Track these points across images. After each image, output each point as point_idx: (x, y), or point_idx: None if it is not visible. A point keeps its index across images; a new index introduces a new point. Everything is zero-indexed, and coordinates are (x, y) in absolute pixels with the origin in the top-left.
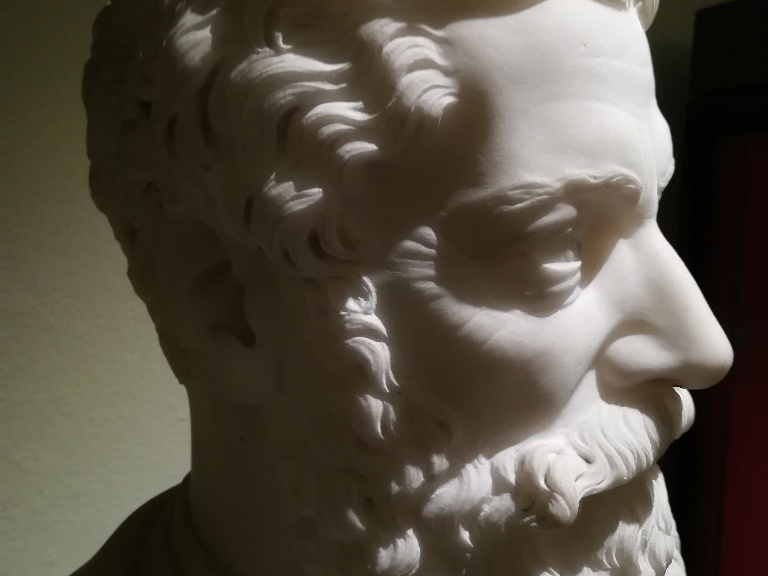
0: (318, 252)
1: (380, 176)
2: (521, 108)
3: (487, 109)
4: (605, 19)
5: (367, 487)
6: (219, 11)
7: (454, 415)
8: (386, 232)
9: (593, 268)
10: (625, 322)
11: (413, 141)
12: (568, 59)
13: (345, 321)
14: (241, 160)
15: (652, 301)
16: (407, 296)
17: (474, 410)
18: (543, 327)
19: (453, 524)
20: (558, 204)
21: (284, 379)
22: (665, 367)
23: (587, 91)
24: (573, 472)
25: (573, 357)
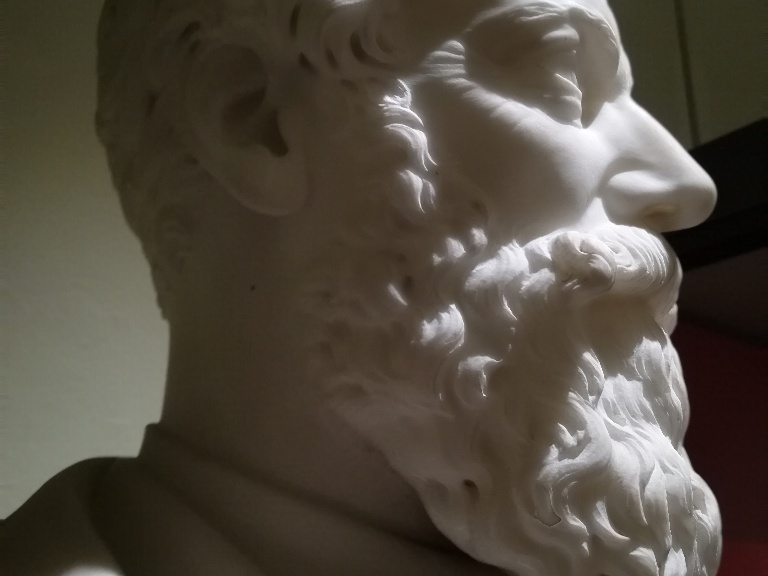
0: (358, 54)
1: None
2: None
3: None
4: None
5: (407, 265)
6: None
7: (488, 200)
8: (418, 44)
9: (587, 120)
10: (621, 159)
11: None
12: None
13: (384, 111)
14: None
15: (641, 144)
16: (440, 92)
17: (505, 198)
18: (560, 129)
19: (497, 294)
20: (565, 24)
21: (314, 189)
22: (663, 191)
23: None
24: (605, 245)
25: (587, 163)
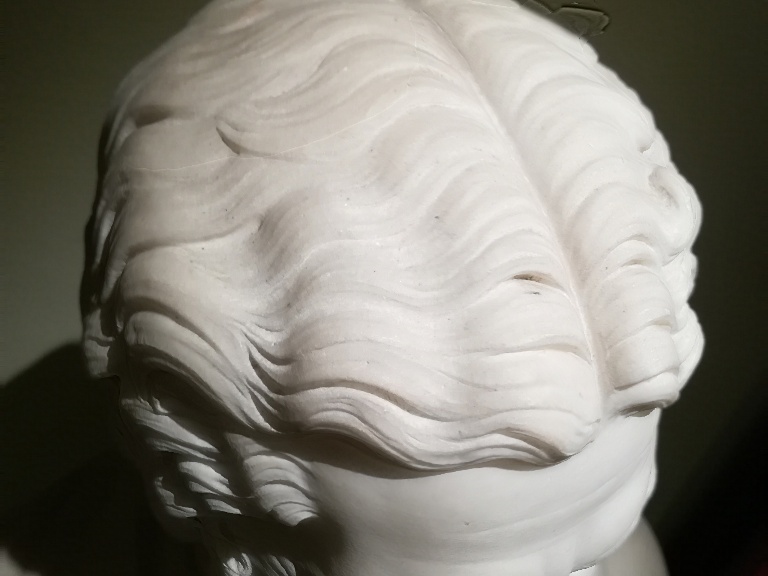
0: None
1: (252, 517)
2: (375, 552)
3: (343, 537)
4: (522, 483)
5: None
6: (115, 341)
7: None
8: (260, 543)
9: None
10: None
11: (275, 520)
12: (438, 534)
13: (226, 571)
14: (139, 450)
15: None
16: None
17: None
18: None
19: None
20: None
21: None
22: None
23: (457, 557)
24: None
25: None
